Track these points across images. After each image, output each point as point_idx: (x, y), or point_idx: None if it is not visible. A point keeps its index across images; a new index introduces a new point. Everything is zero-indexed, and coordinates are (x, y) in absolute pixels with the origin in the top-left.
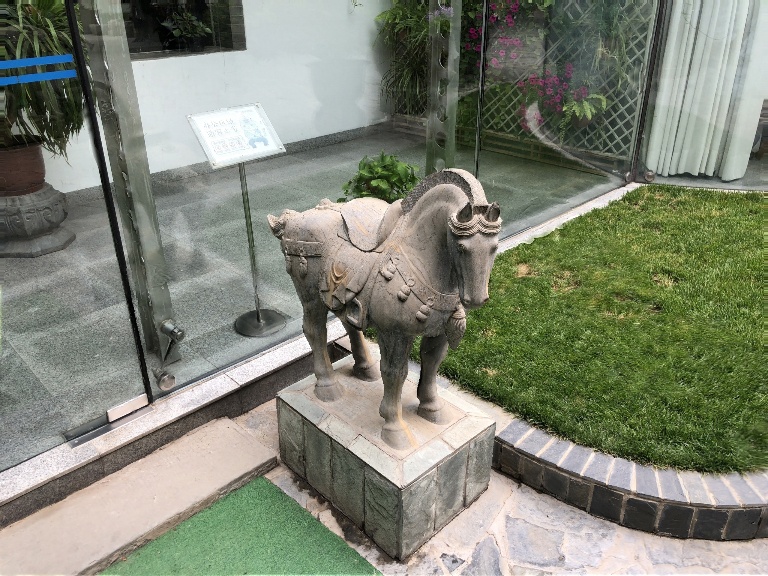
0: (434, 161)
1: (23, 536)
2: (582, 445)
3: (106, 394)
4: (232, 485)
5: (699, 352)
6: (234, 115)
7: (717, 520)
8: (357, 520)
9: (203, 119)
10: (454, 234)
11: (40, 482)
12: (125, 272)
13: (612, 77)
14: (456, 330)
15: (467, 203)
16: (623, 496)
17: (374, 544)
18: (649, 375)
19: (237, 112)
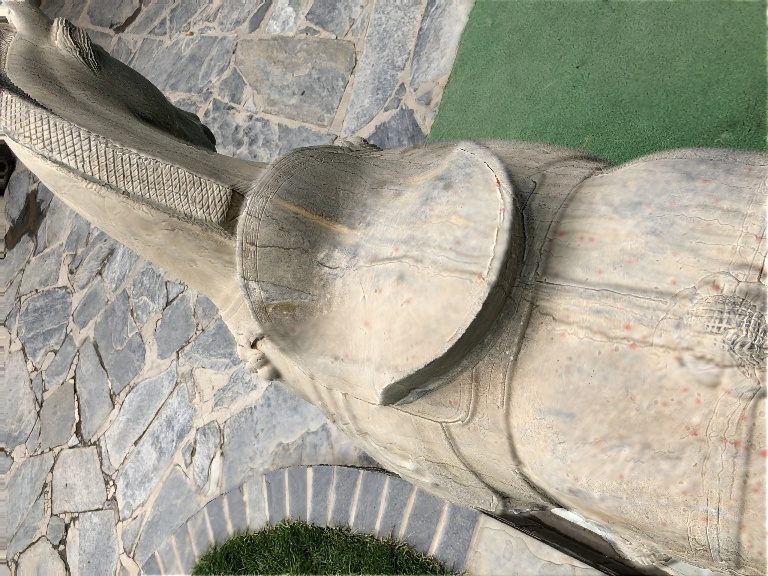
0: None
1: None
2: None
3: None
4: None
5: None
6: None
7: None
8: None
9: None
10: None
11: None
12: None
13: None
14: None
15: None
16: None
17: None
18: None
19: None
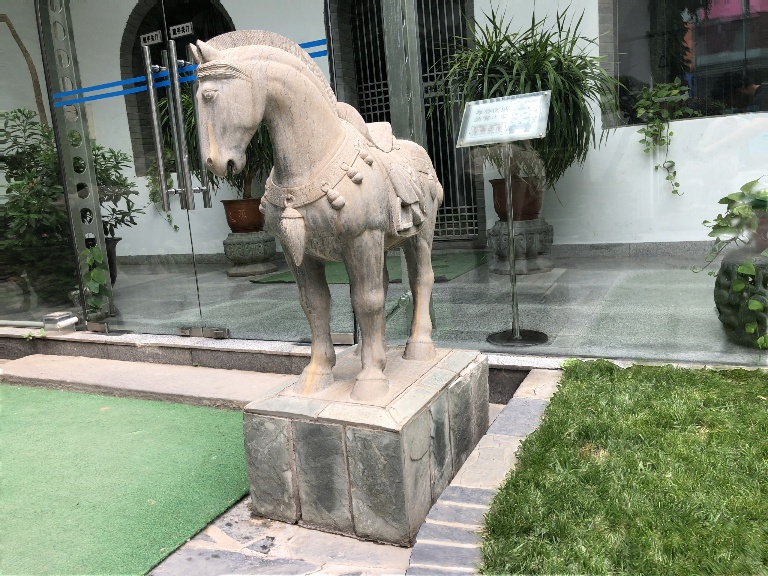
0: None
1: (226, 374)
2: None
3: None
4: None
5: None
6: (514, 104)
7: None
8: None
9: (482, 108)
10: None
11: (254, 349)
12: None
13: None
14: None
15: None
16: None
17: None
18: None
19: (519, 102)
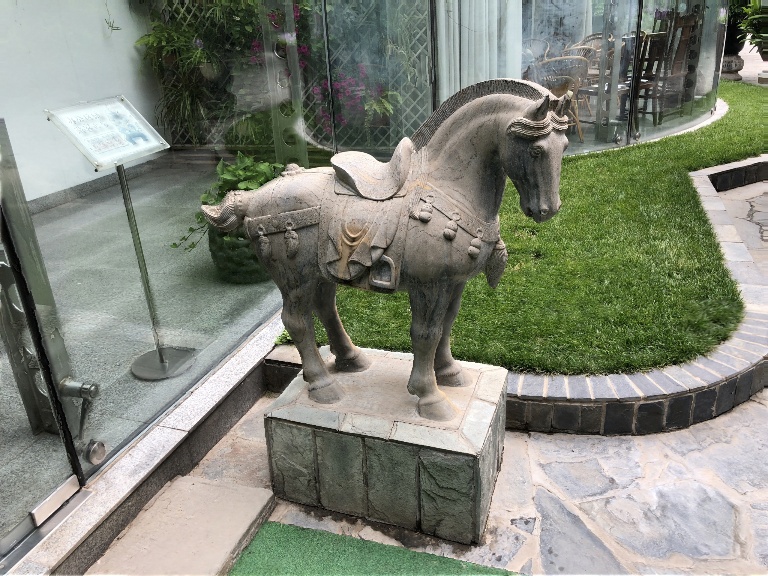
0: (283, 161)
1: None
2: (574, 374)
3: (6, 497)
4: (242, 543)
5: (600, 278)
6: (98, 108)
7: (709, 399)
8: (408, 522)
9: (63, 114)
10: (528, 137)
11: None
12: (31, 309)
13: (401, 73)
14: (501, 263)
15: (545, 97)
16: (634, 405)
17: (439, 539)
18: (579, 305)
19: (100, 105)
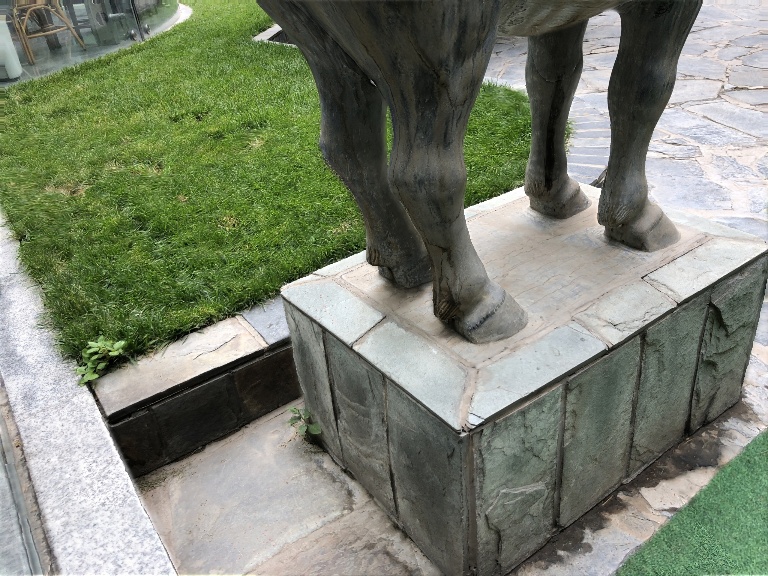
0: None
1: None
2: None
3: None
4: None
5: None
6: None
7: None
8: (677, 434)
9: None
10: None
11: None
12: None
13: None
14: None
15: None
16: None
17: (713, 424)
18: None
19: None
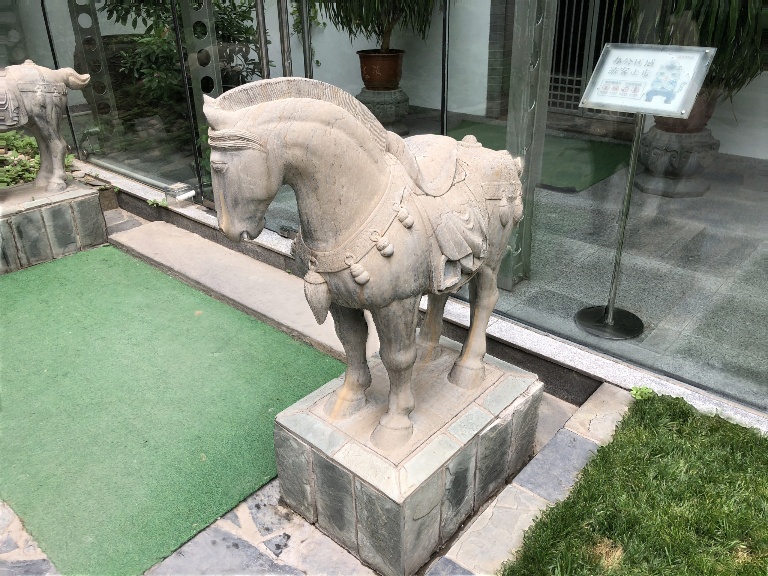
0: None
1: None
2: None
3: None
4: None
5: None
6: (663, 57)
7: None
8: None
9: (623, 53)
10: None
11: None
12: None
13: None
14: None
15: None
16: None
17: None
18: None
19: (671, 55)
